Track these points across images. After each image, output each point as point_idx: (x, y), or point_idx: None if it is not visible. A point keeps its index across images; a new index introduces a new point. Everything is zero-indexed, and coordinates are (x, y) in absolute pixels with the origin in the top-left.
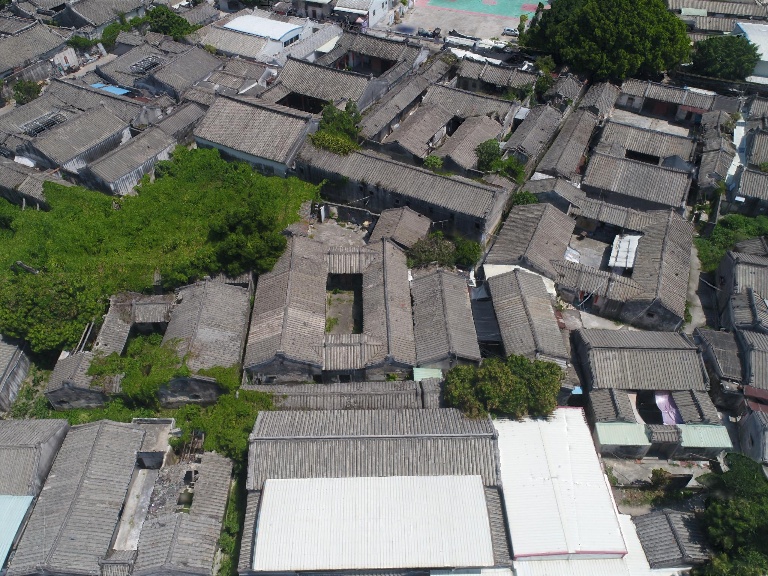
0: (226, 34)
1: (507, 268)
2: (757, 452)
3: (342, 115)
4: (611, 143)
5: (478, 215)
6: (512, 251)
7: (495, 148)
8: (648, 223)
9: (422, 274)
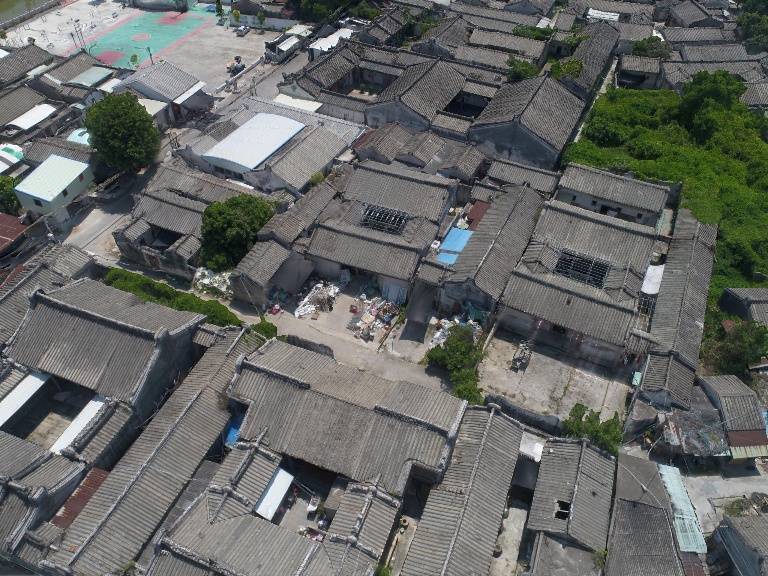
0: (291, 159)
1: (655, 35)
2: (723, 8)
3: (527, 64)
4: (494, 1)
5: (619, 34)
6: (642, 31)
7: (526, 28)
8: (582, 3)
9: (676, 59)
